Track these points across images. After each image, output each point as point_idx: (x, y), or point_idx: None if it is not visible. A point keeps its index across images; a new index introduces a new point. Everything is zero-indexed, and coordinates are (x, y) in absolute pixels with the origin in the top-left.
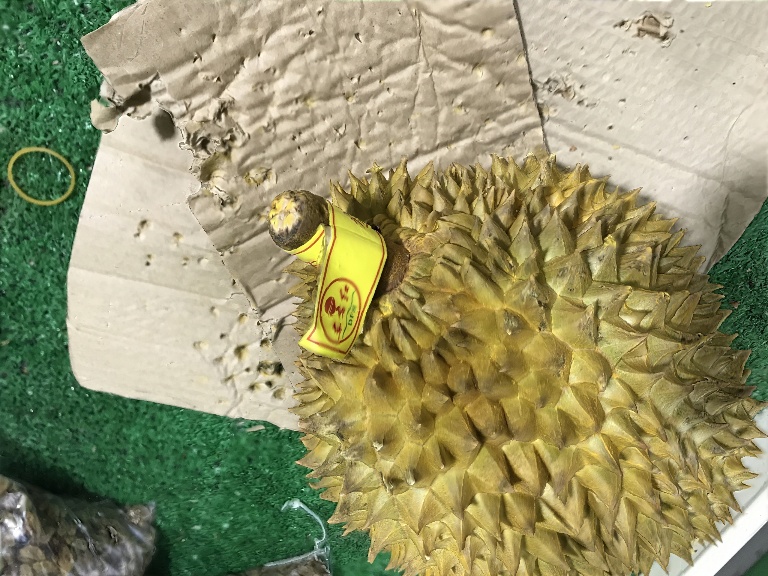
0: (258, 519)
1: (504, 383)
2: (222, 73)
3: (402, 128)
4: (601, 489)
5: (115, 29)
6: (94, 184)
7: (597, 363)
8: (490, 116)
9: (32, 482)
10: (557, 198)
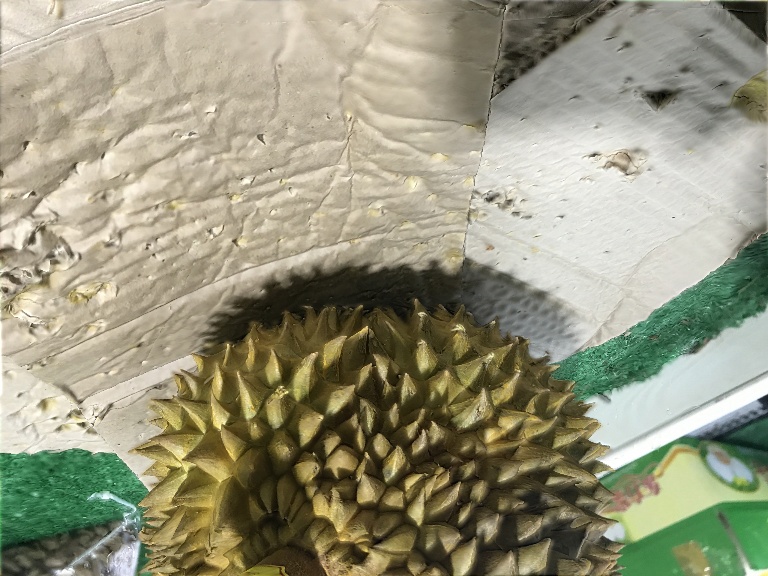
0: (58, 506)
1: None
2: (39, 187)
3: (299, 225)
4: None
5: None
6: None
7: None
8: (411, 220)
9: None
10: (492, 434)
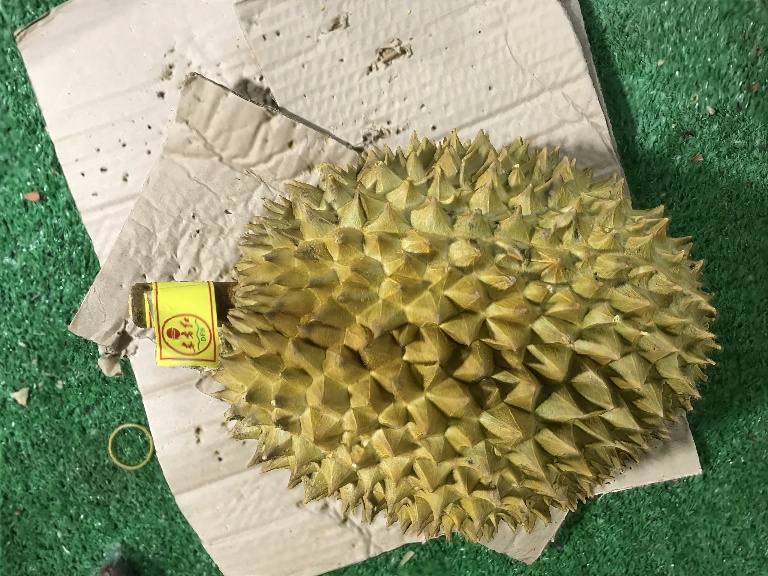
0: None
1: (292, 293)
2: None
3: None
4: (425, 315)
5: (84, 311)
6: (153, 425)
7: (335, 232)
8: None
9: None
10: None
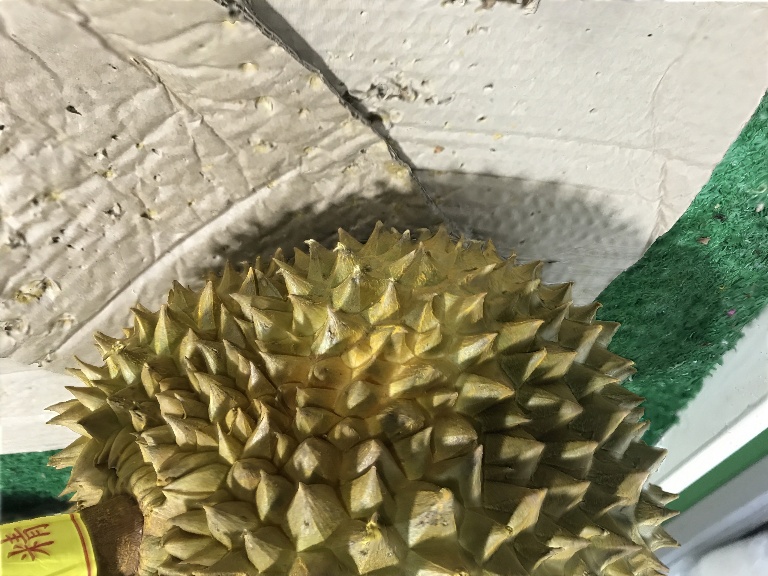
0: None
1: None
2: None
3: (196, 184)
4: None
5: None
6: None
7: None
8: (307, 145)
9: (1, 508)
10: (356, 357)
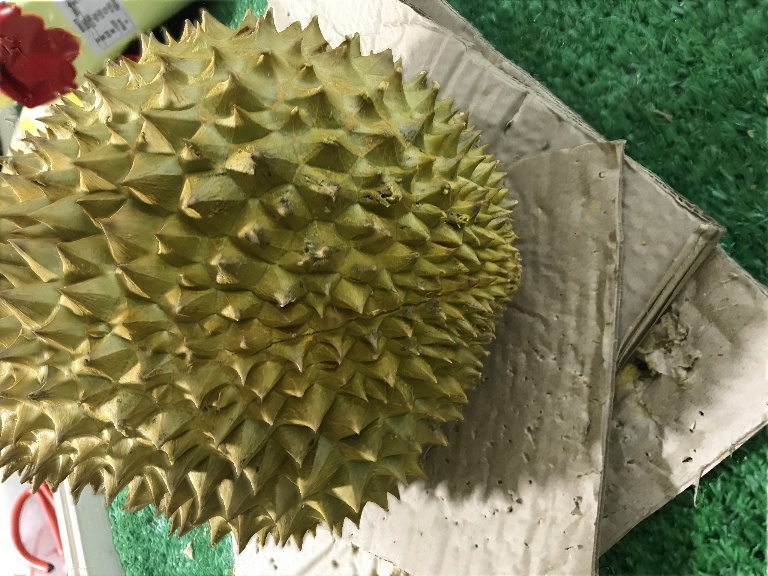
0: None
1: None
2: None
3: None
4: None
5: None
6: None
7: None
8: None
9: None
10: None
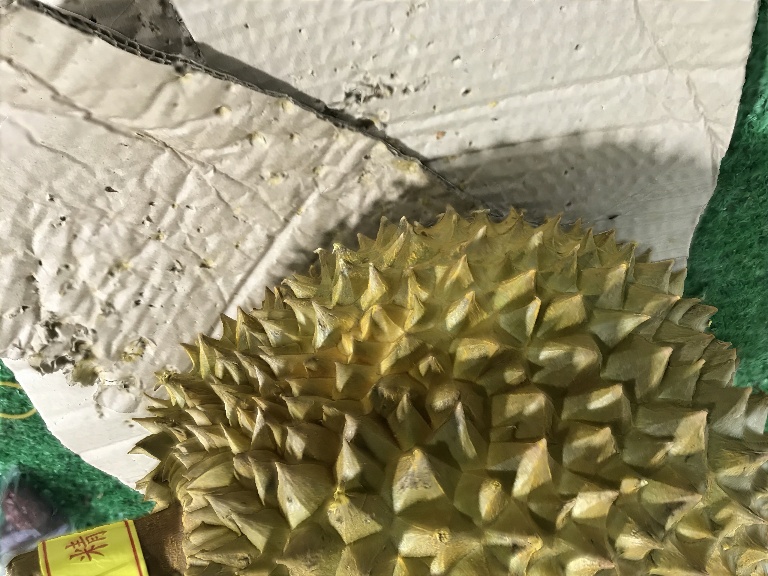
0: None
1: None
2: (22, 302)
3: (235, 227)
4: None
5: None
6: (36, 401)
7: None
8: (313, 166)
9: None
10: (348, 343)
